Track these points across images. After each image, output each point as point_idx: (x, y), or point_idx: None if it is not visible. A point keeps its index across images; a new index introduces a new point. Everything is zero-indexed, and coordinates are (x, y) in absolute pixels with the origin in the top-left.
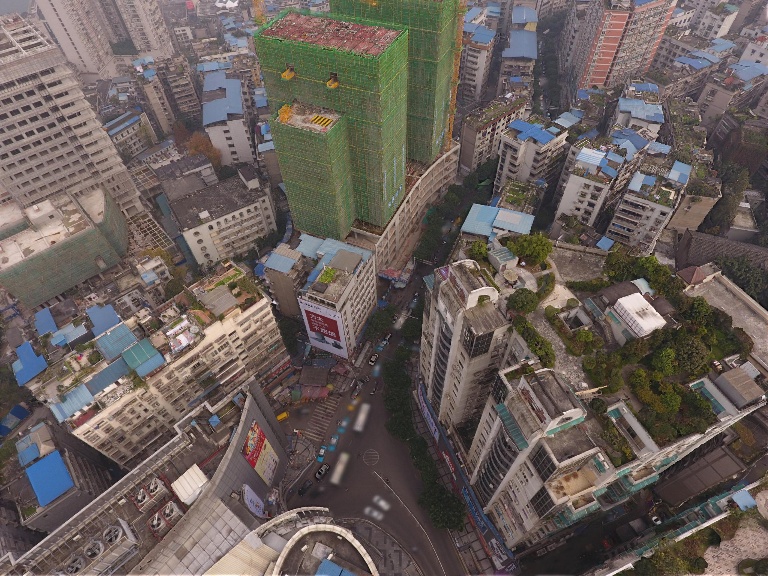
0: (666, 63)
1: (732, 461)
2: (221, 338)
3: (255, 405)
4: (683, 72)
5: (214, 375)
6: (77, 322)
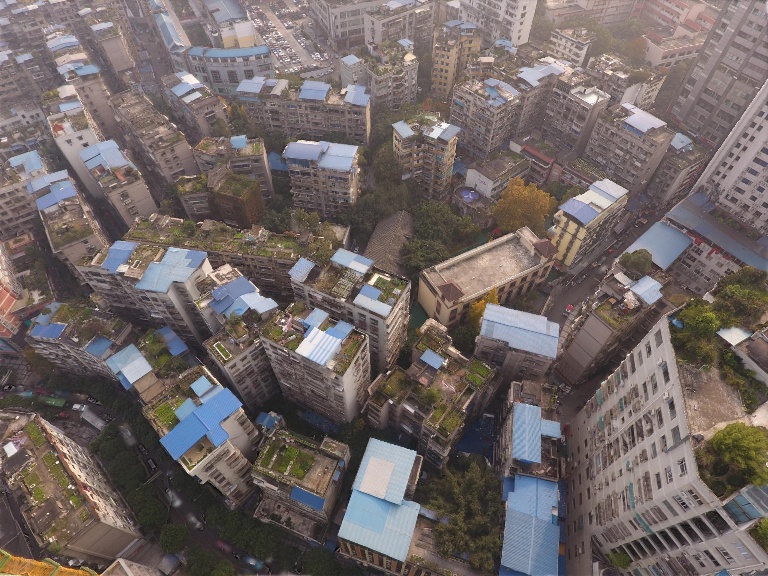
0: (1, 220)
1: None
2: None
3: None
4: (68, 209)
5: None
6: None
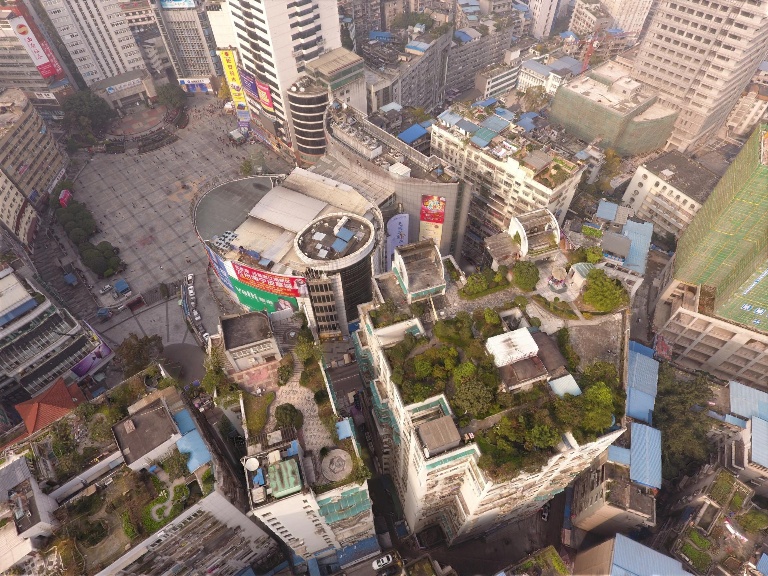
0: None
1: None
2: (511, 176)
3: (455, 195)
4: None
5: (490, 194)
6: (517, 116)
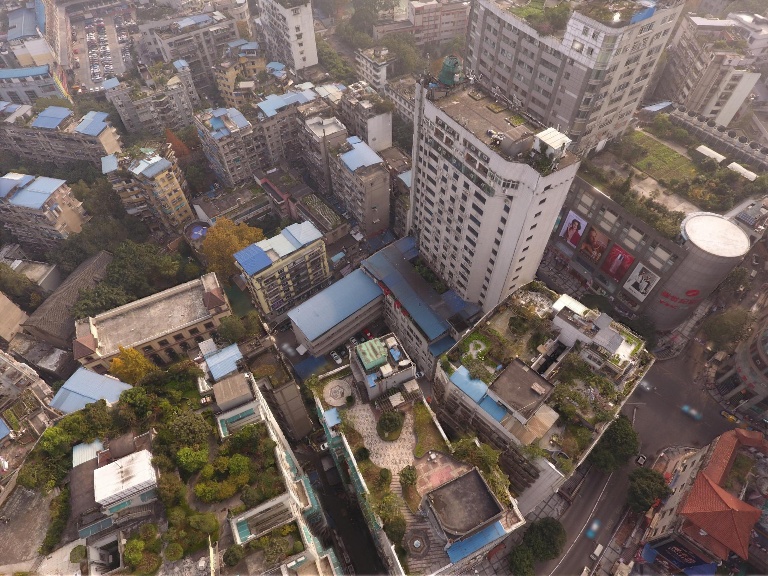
0: None
1: (287, 389)
2: None
3: None
4: None
5: None
6: None
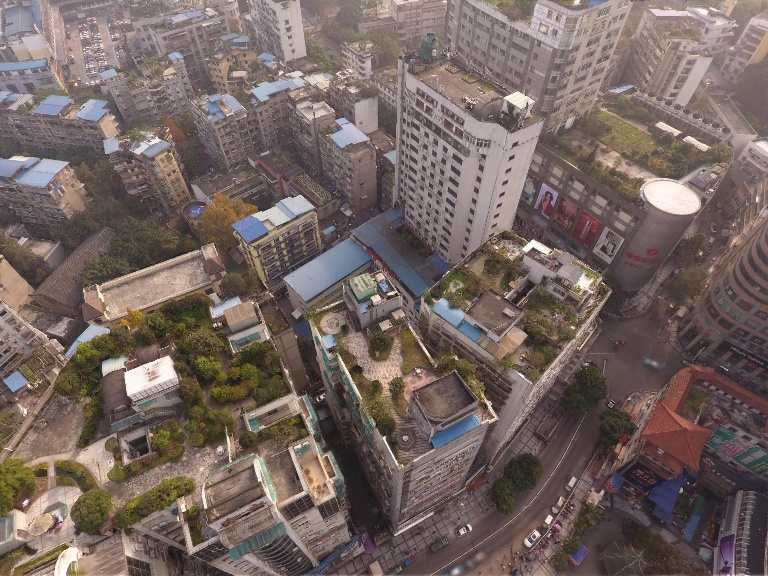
0: None
1: (286, 335)
2: None
3: None
4: None
5: None
6: None
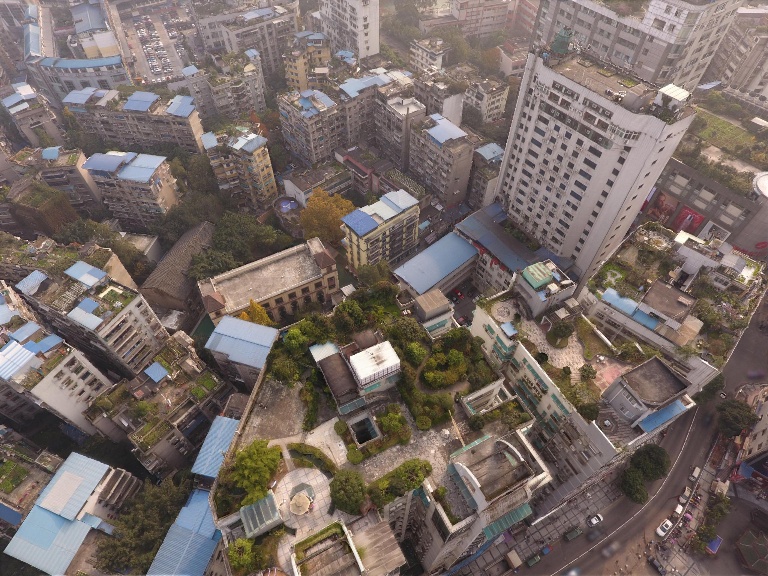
0: None
1: None
2: None
3: None
4: None
5: None
6: None
